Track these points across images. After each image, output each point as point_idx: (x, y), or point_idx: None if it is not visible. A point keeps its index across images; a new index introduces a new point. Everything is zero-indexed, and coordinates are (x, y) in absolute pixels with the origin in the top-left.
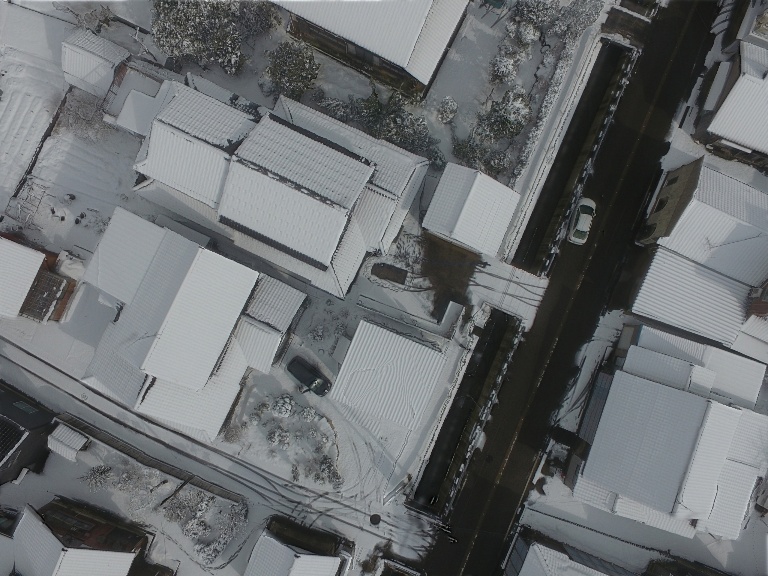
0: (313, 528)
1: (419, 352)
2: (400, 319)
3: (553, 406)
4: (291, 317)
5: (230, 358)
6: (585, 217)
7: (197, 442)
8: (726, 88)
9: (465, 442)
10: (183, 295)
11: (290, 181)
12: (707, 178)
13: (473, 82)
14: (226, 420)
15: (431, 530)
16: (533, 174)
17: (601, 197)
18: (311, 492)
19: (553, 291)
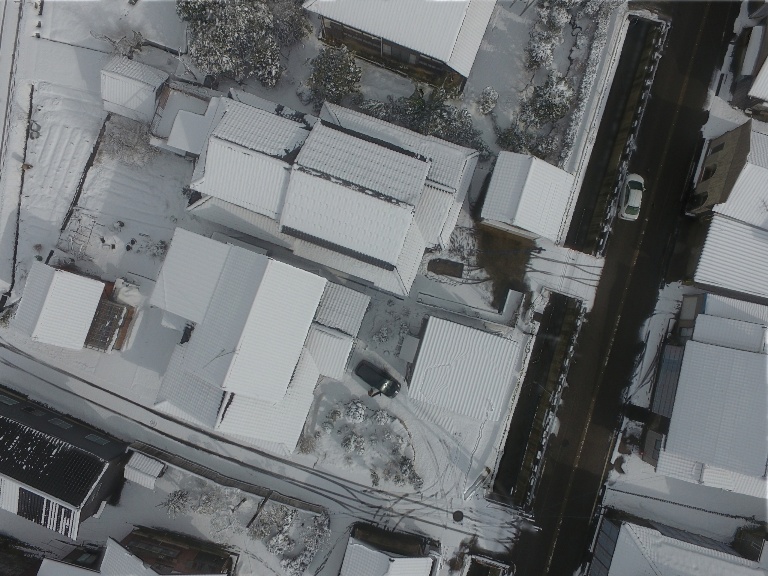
0: (396, 531)
1: (491, 342)
2: (462, 312)
3: (623, 384)
4: (360, 320)
5: (302, 368)
6: (635, 192)
7: (272, 457)
8: (762, 52)
9: (538, 429)
10: (257, 308)
11: (353, 184)
12: (755, 141)
13: (508, 71)
14: (301, 431)
15: (515, 521)
16: (577, 156)
17: (647, 171)
18: (390, 495)
19: (610, 269)
